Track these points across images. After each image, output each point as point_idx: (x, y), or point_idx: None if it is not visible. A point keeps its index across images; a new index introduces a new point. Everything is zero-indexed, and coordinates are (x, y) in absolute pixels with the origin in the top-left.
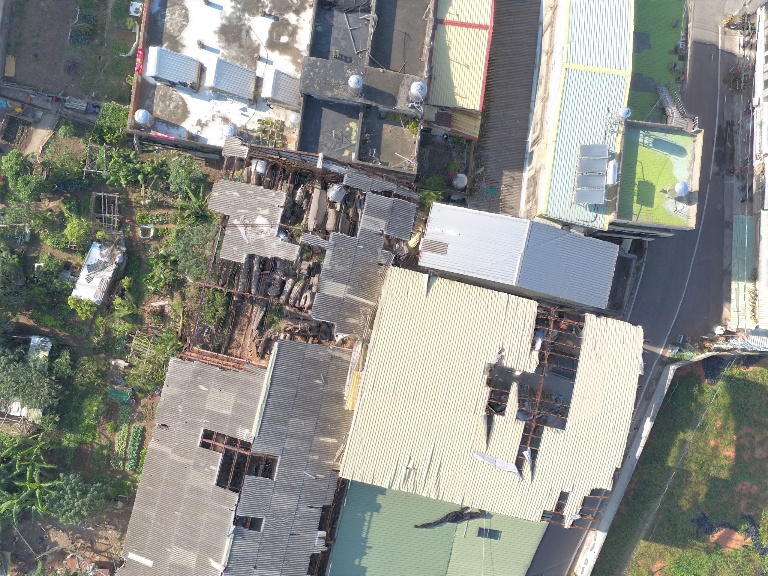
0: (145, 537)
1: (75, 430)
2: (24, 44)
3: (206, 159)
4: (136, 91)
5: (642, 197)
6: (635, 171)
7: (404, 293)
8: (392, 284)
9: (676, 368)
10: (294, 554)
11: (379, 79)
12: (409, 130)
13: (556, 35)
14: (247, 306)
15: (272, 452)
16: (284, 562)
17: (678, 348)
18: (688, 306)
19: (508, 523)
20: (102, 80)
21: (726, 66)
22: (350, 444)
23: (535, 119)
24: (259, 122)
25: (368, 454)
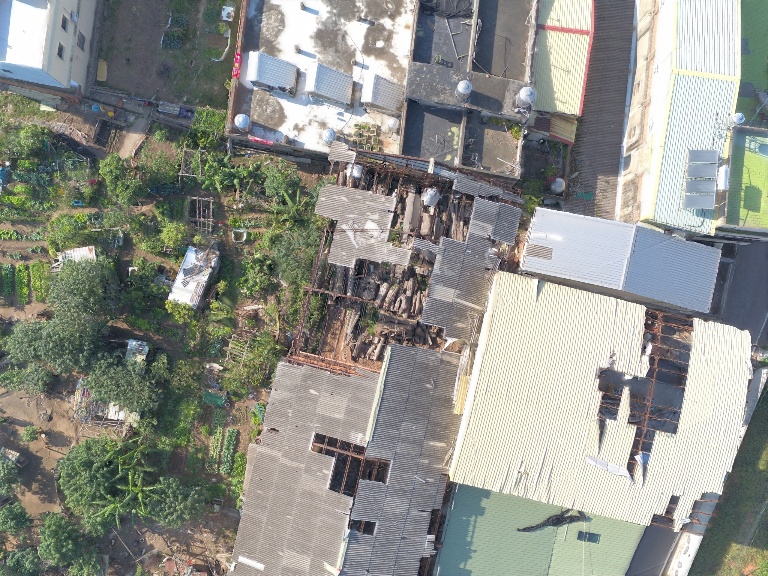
0: (256, 541)
1: (170, 434)
2: (116, 48)
3: (298, 163)
4: (234, 96)
5: (749, 202)
6: (742, 176)
7: (514, 298)
8: (502, 289)
9: None
10: (405, 558)
11: (485, 84)
12: (511, 135)
13: (658, 40)
14: (340, 310)
15: (385, 456)
16: (395, 566)
17: None
18: None
19: (607, 527)
20: (194, 84)
21: None
22: (462, 448)
23: (631, 124)
24: (356, 127)
25: (480, 458)
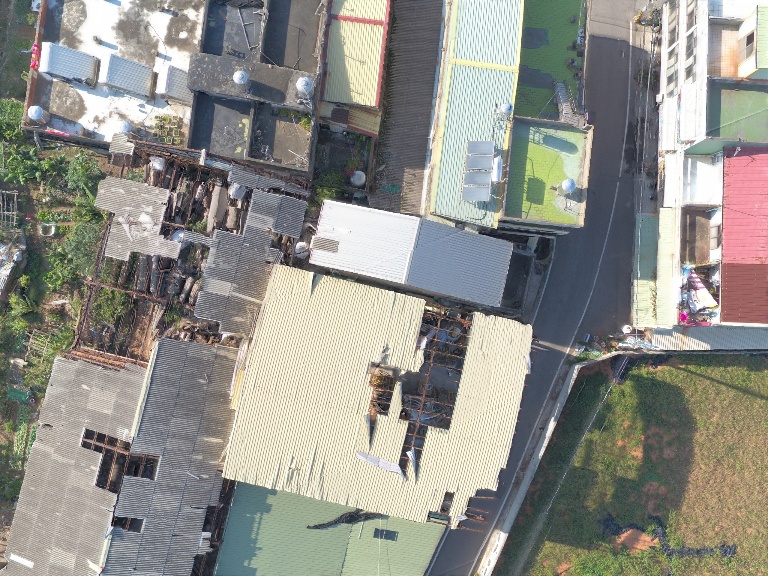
0: (27, 538)
1: None
2: None
3: (109, 156)
4: (31, 87)
5: (532, 194)
6: (525, 168)
7: (288, 291)
8: (276, 282)
9: (580, 367)
10: (177, 555)
11: (268, 75)
12: (302, 127)
13: (450, 30)
14: (149, 305)
15: (152, 452)
16: (166, 563)
17: (584, 347)
18: (596, 305)
19: (405, 524)
20: (4, 76)
21: (637, 62)
22: (232, 444)
23: (435, 116)
24: (156, 119)
25: (250, 454)
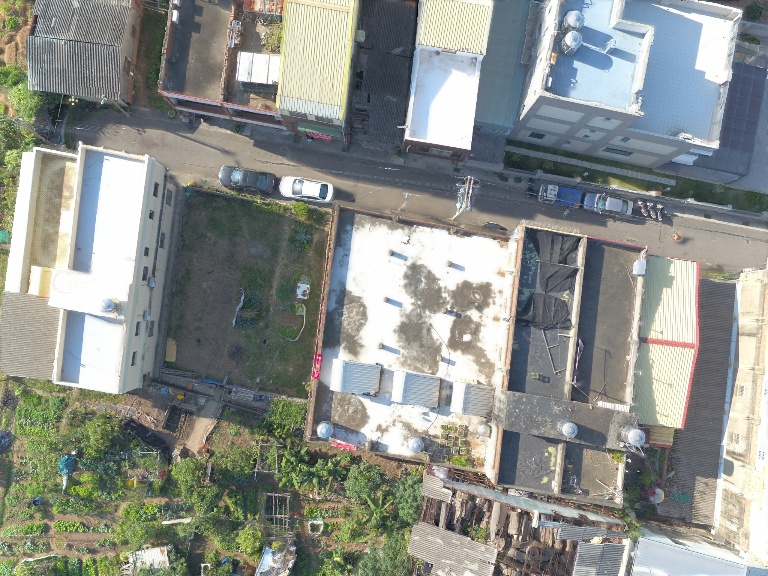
0: None
1: None
2: (186, 328)
3: None
4: (315, 399)
5: None
6: None
7: None
8: None
9: None
10: None
11: (588, 416)
12: None
13: None
14: None
15: None
16: None
17: None
18: None
19: None
20: (267, 365)
21: None
22: None
23: (733, 428)
24: (443, 429)
25: None
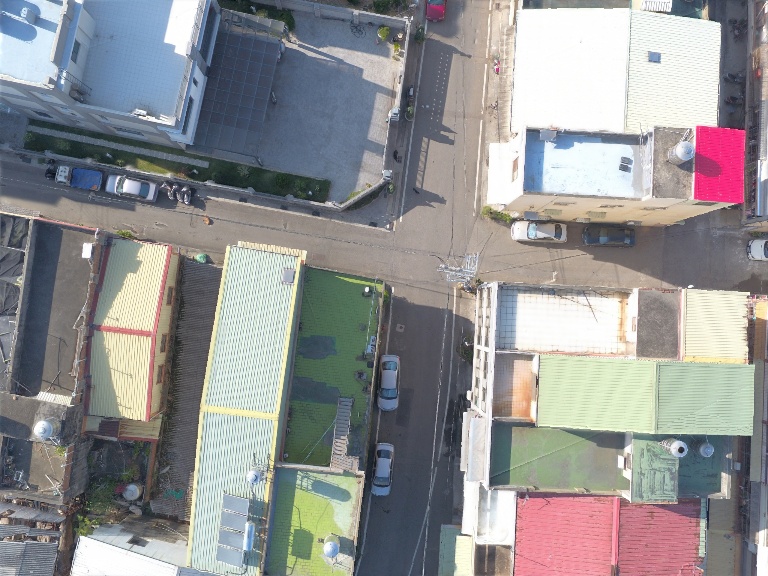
0: None
1: None
2: None
3: None
4: None
5: (298, 547)
6: (291, 518)
7: None
8: None
9: None
10: None
11: (12, 407)
12: None
13: None
14: None
15: None
16: None
17: None
18: None
19: None
20: None
21: None
22: None
23: None
24: None
25: None
